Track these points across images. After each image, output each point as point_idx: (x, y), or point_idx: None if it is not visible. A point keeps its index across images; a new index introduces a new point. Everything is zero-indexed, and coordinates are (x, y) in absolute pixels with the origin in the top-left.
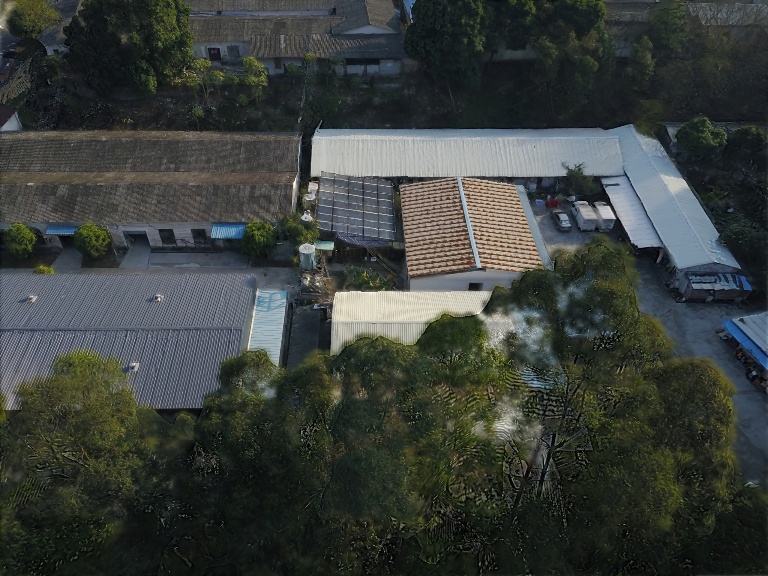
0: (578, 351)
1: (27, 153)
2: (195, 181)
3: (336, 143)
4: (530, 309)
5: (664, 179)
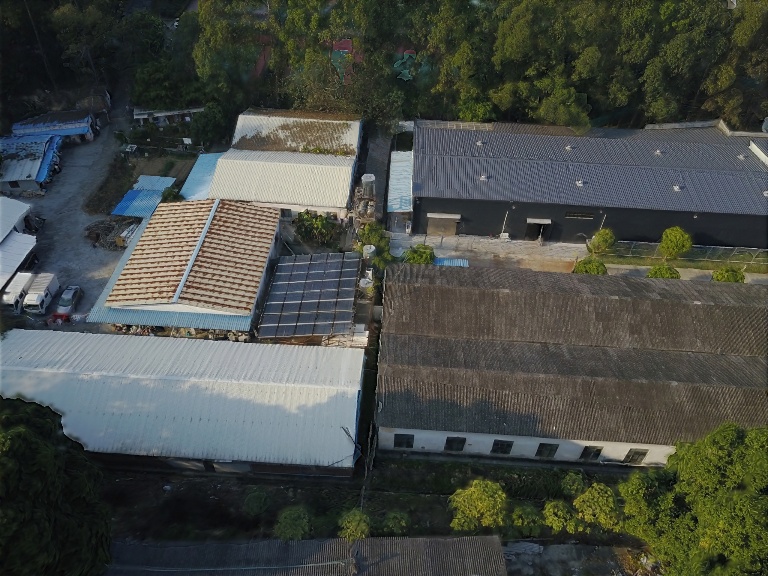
0: None
1: (767, 374)
2: (505, 298)
3: (323, 380)
4: None
5: None
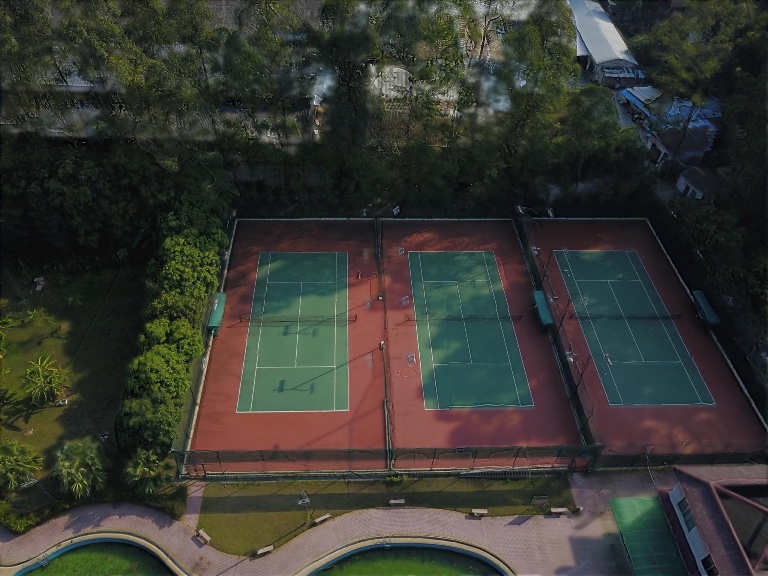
0: None
1: None
2: None
3: None
4: None
5: (597, 21)
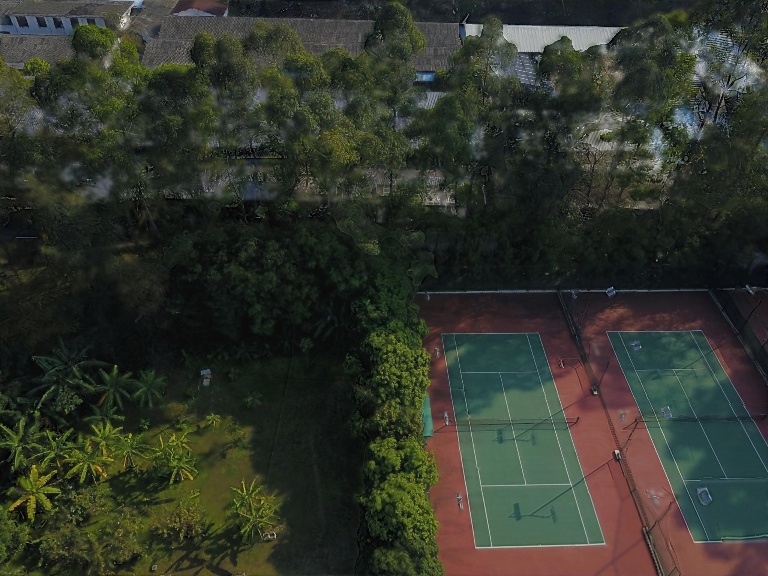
0: (754, 12)
1: None
2: None
3: None
4: (722, 5)
5: None
